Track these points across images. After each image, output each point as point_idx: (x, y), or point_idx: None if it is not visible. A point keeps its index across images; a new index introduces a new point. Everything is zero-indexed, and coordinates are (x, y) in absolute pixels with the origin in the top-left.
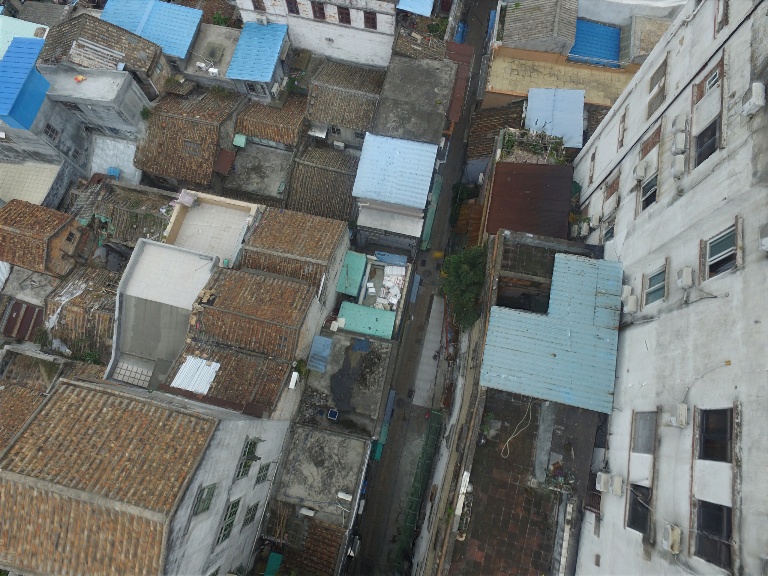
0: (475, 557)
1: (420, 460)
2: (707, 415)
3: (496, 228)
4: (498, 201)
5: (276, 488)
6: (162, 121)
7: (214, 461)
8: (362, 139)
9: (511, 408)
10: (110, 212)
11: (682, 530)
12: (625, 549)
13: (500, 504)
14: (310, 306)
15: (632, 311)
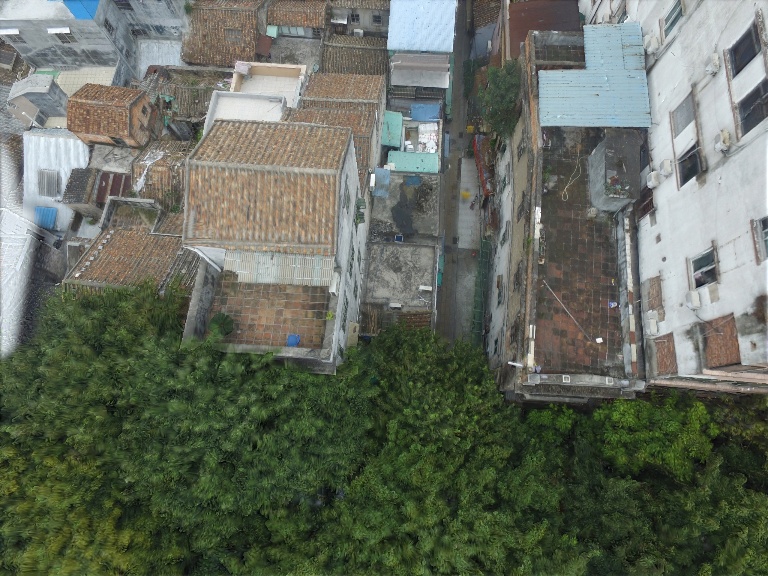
0: (555, 275)
1: (477, 280)
2: (734, 50)
3: (519, 53)
4: (517, 33)
5: (363, 294)
6: (203, 14)
7: (350, 168)
8: (379, 23)
9: (563, 165)
10: (173, 91)
11: (729, 132)
12: (682, 202)
13: (568, 234)
14: (374, 125)
15: (655, 48)
